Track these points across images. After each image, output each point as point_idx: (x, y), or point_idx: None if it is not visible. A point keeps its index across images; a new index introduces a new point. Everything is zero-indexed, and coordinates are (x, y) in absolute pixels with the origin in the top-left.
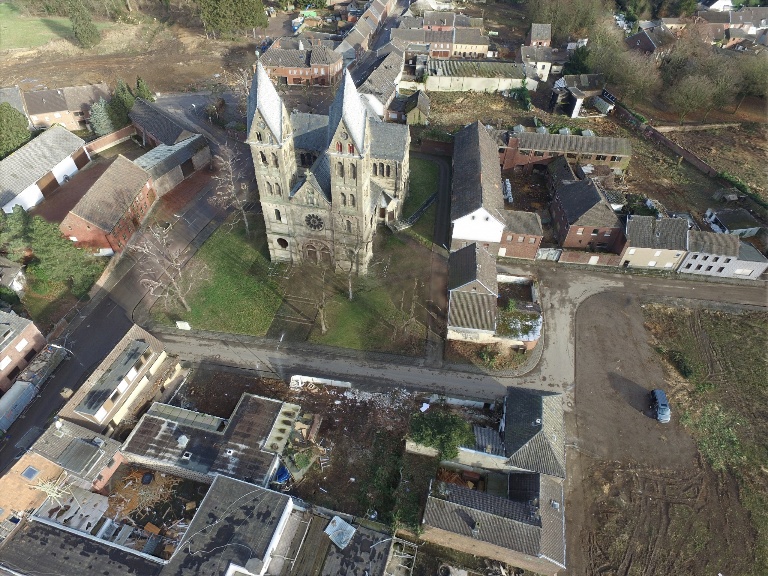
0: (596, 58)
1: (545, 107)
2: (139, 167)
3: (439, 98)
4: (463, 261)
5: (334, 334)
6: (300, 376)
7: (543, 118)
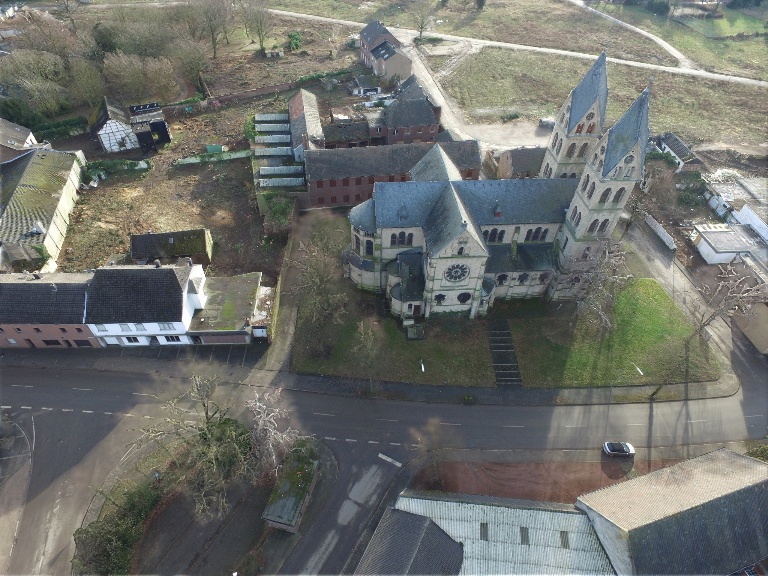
0: (50, 96)
1: (138, 157)
2: (595, 510)
3: (94, 246)
4: (527, 159)
5: (616, 239)
6: (671, 237)
7: (172, 159)
